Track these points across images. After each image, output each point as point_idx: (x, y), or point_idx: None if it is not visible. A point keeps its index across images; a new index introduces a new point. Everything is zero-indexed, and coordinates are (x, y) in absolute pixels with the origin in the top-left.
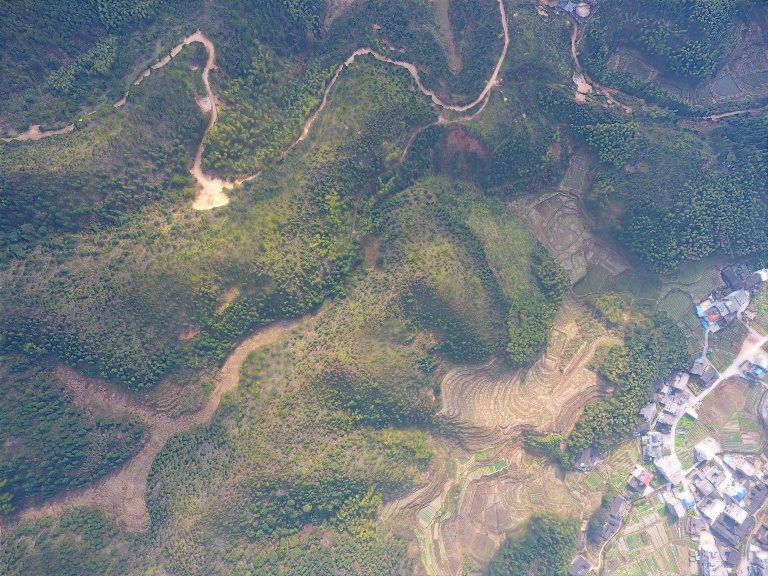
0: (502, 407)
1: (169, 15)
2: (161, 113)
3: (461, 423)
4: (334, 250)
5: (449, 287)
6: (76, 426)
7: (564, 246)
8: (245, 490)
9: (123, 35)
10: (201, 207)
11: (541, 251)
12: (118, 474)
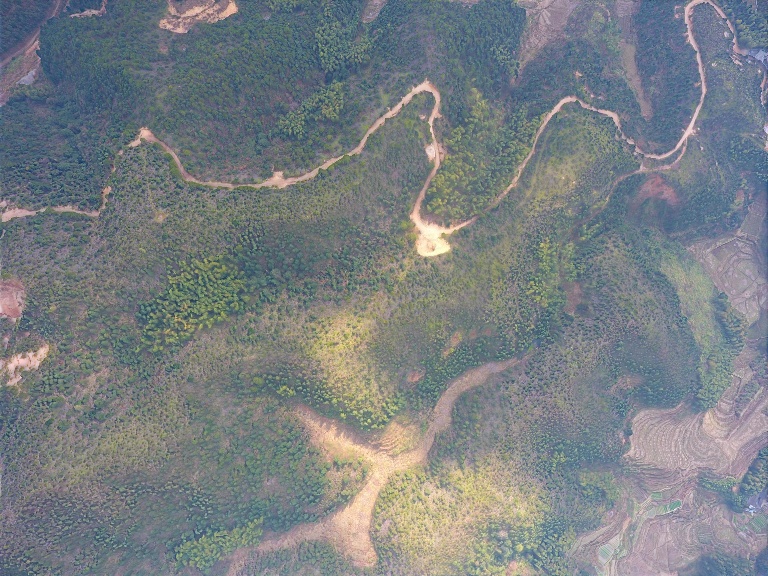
0: (682, 449)
1: (385, 60)
2: (396, 162)
3: (645, 465)
4: (545, 297)
5: (658, 336)
6: (318, 465)
7: (738, 291)
8: (473, 531)
9: (342, 80)
10: (425, 253)
11: (721, 296)
12: (344, 509)
